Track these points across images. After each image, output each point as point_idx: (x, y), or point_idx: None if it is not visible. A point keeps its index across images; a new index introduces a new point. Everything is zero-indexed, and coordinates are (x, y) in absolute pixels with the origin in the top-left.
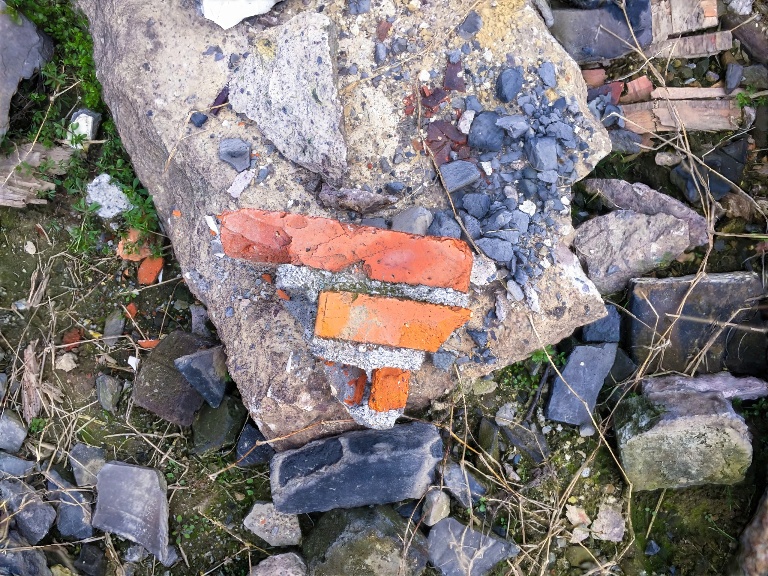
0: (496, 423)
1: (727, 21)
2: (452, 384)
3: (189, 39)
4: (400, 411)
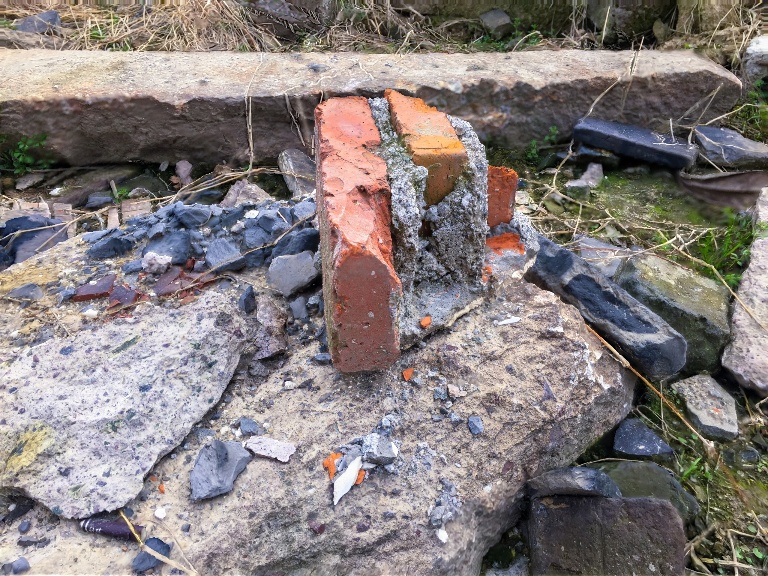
0: None
1: None
2: None
3: None
4: None
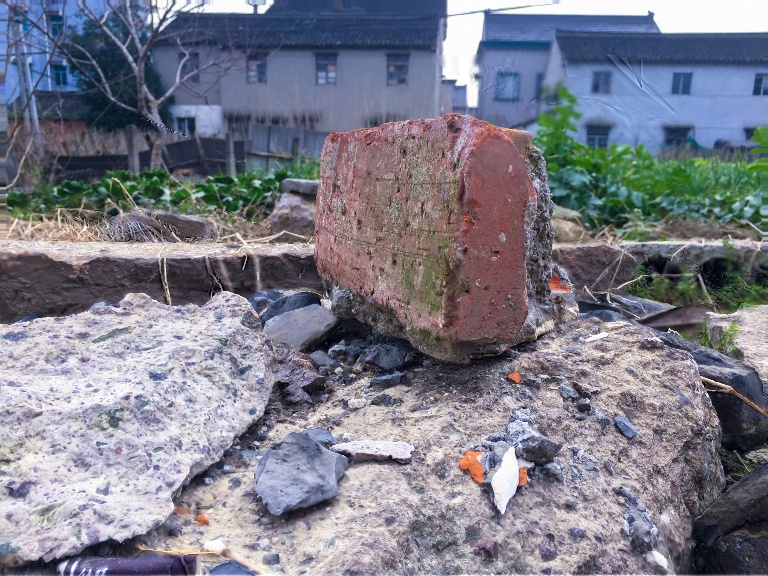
0: None
1: None
2: None
3: None
4: None
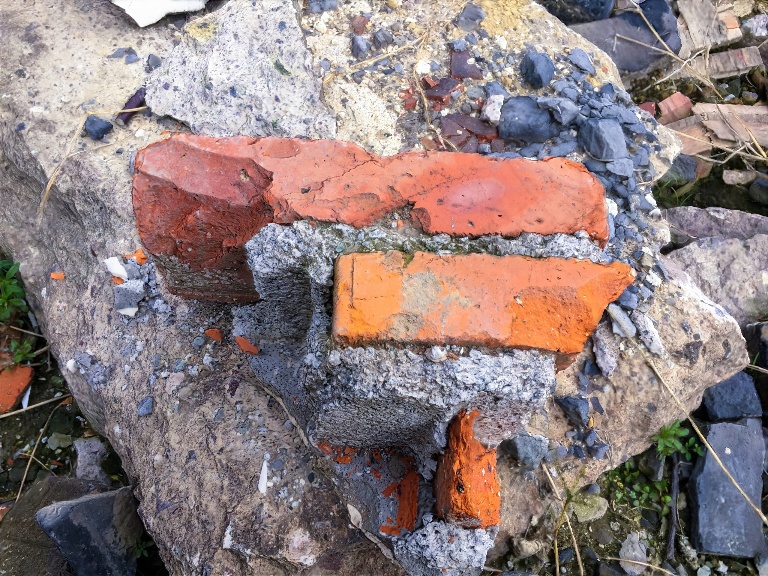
0: (624, 570)
1: (743, 45)
2: (540, 506)
3: (88, 41)
4: (493, 532)
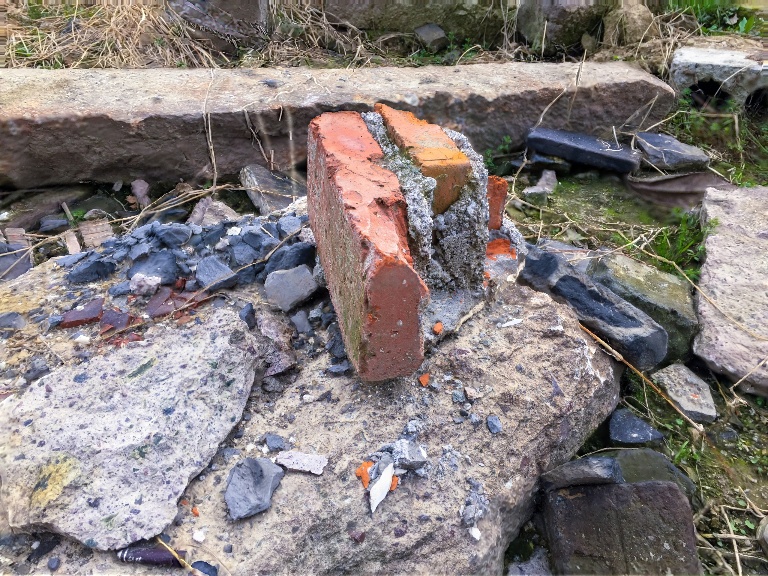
0: None
1: None
2: None
3: None
4: None
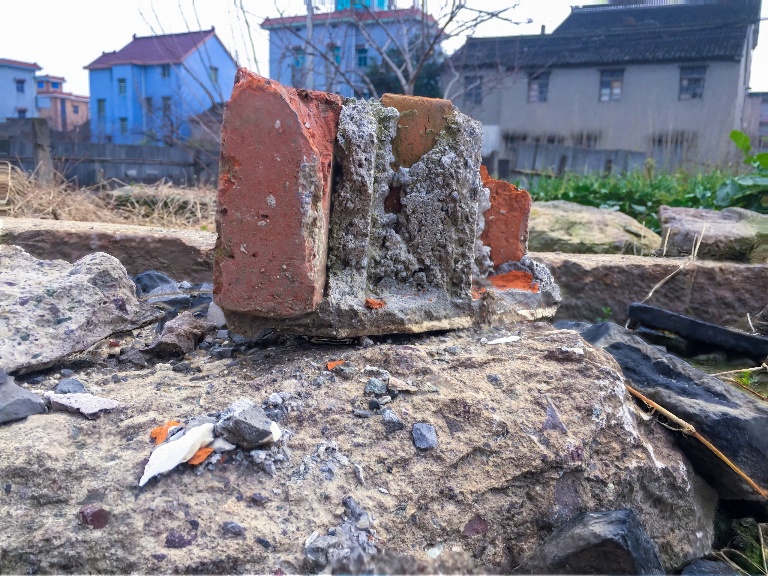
0: None
1: None
2: None
3: None
4: None
